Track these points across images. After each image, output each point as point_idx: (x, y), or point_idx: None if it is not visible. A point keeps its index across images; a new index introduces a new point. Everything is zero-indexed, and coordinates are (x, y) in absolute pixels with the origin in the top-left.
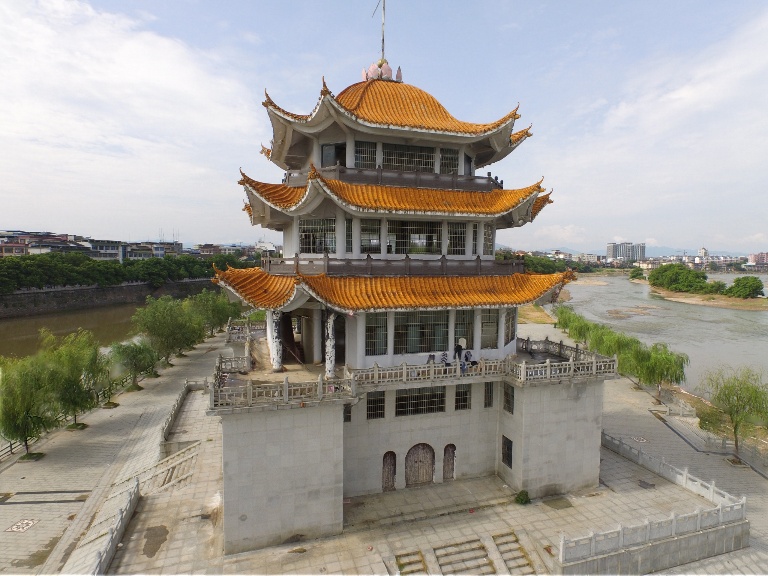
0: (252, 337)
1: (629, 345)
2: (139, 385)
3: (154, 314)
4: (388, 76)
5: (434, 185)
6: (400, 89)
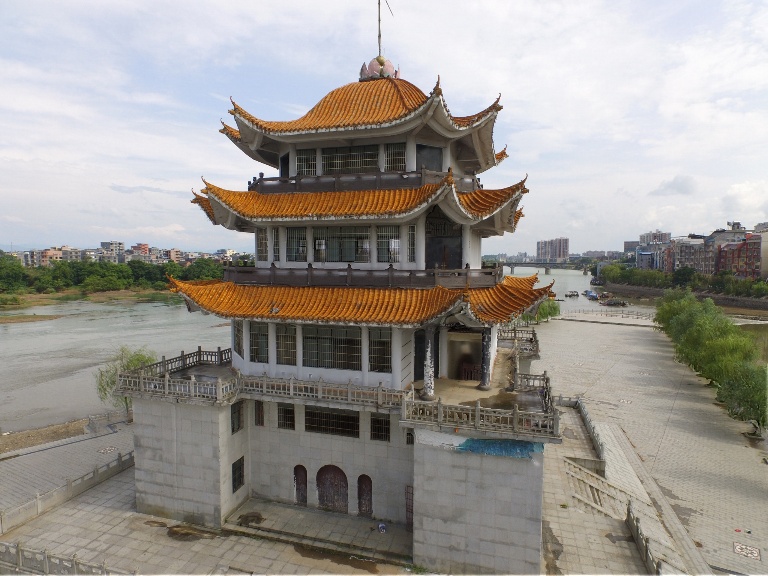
0: (510, 396)
1: None
2: None
3: None
4: None
5: None
6: None
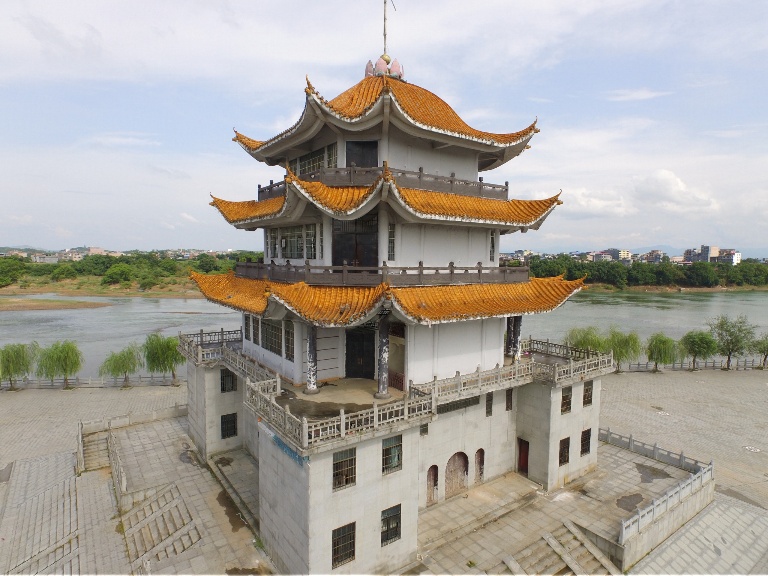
0: None
1: (74, 351)
2: None
3: None
4: None
5: None
6: None
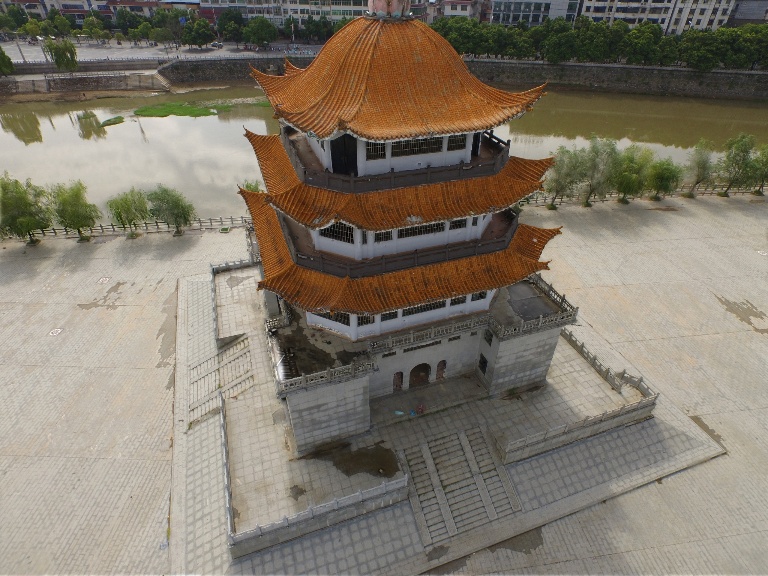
0: None
1: None
2: (526, 209)
3: (590, 153)
4: (371, 10)
5: (293, 159)
6: (342, 40)
